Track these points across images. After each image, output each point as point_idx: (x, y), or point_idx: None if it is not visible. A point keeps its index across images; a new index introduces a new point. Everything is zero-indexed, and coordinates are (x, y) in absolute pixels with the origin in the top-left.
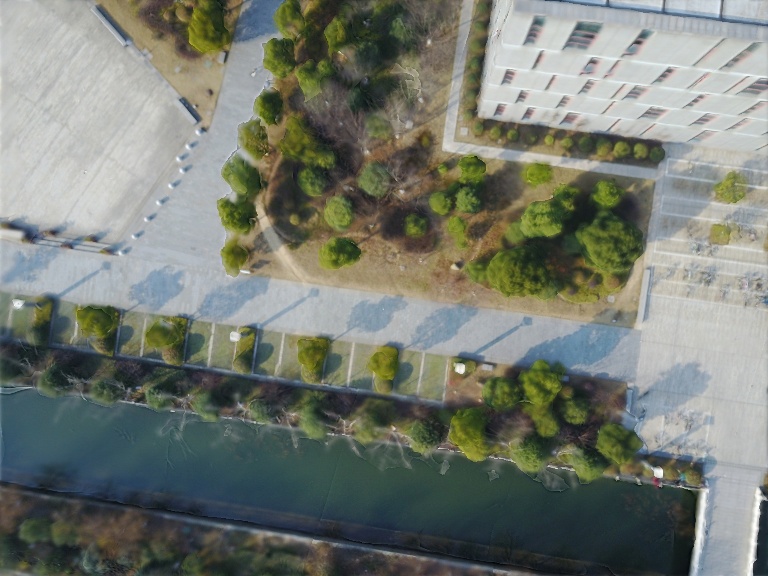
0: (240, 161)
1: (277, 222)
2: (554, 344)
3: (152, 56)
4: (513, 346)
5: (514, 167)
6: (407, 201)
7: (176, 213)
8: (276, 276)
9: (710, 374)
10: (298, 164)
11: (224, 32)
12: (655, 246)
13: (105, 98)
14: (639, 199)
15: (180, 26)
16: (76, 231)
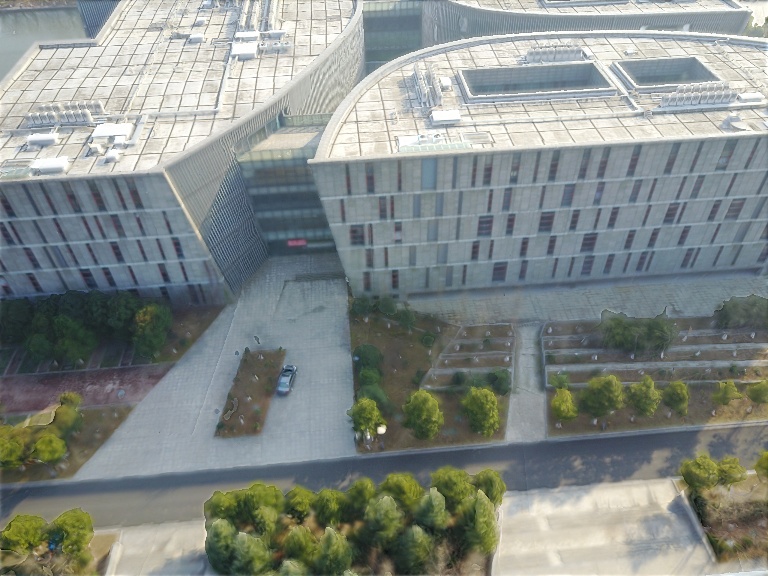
0: None
1: None
2: None
3: None
4: None
5: None
6: None
7: None
8: None
9: None
10: None
11: None
12: None
13: (757, 22)
14: None
15: None
16: None
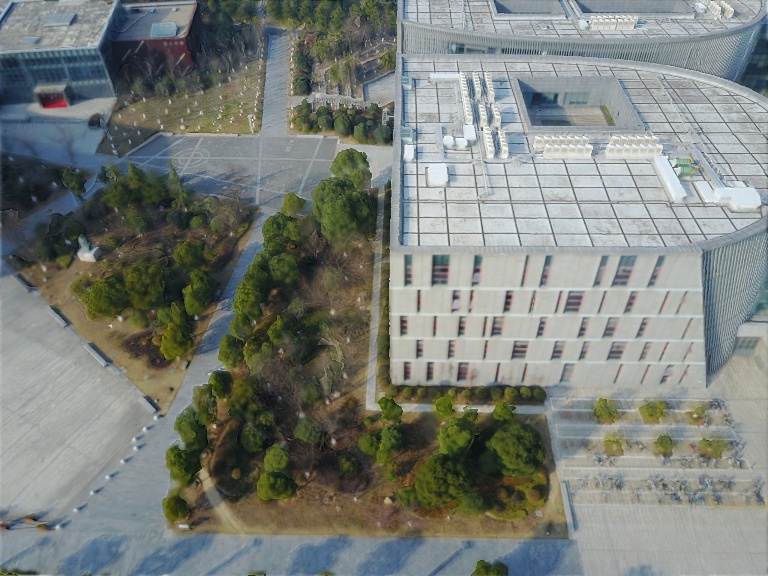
0: (192, 412)
1: (219, 480)
2: (497, 565)
3: (126, 371)
4: (457, 572)
5: (428, 416)
6: (339, 450)
7: (123, 484)
8: (214, 531)
9: (658, 575)
10: (242, 423)
11: (189, 339)
12: (563, 464)
13: (78, 402)
14: (537, 429)
15: (154, 348)
16: (17, 513)
